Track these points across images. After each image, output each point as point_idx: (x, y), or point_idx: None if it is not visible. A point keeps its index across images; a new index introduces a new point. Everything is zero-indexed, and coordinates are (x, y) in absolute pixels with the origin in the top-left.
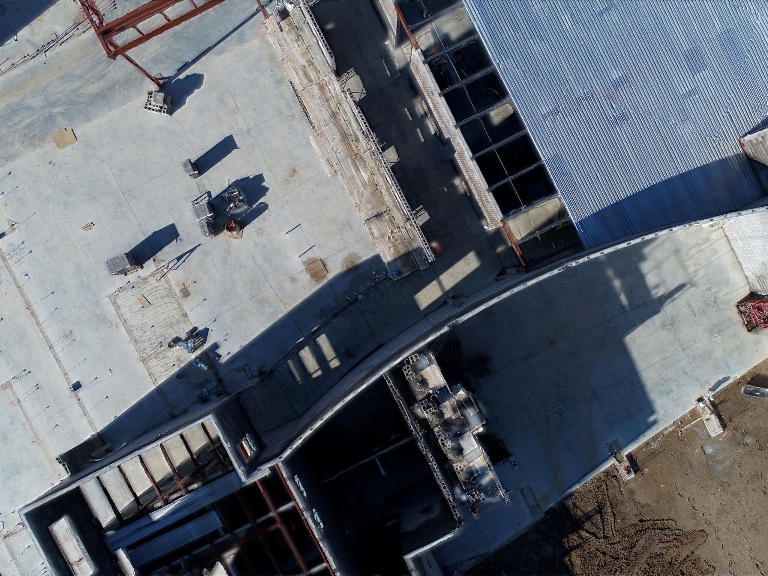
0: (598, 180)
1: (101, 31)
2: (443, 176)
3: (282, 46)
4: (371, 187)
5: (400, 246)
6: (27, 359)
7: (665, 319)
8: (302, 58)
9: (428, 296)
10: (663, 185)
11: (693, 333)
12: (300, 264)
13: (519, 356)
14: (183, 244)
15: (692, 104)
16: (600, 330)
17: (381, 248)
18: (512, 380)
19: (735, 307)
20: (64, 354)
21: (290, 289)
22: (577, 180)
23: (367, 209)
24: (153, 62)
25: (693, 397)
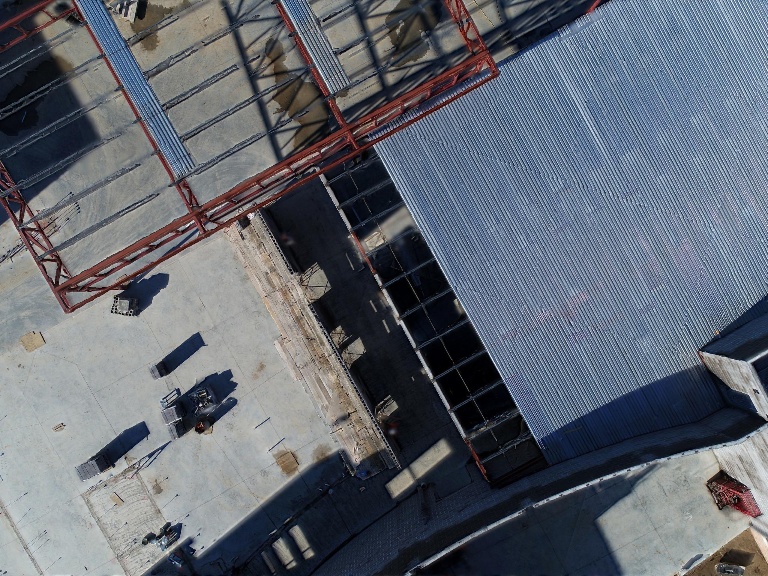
0: (559, 397)
1: (57, 290)
2: (410, 366)
3: (244, 254)
4: (335, 401)
5: (368, 446)
6: (3, 560)
7: (636, 499)
8: (264, 265)
9: (399, 485)
10: (624, 399)
11: (664, 512)
12: (271, 457)
13: (492, 541)
14: (154, 441)
15: (650, 318)
16: (572, 512)
17: (347, 460)
18: (486, 565)
19: (705, 486)
20: (39, 554)
21: (262, 482)
22: (538, 398)
23: (332, 422)
24: (118, 263)
25: (667, 575)
